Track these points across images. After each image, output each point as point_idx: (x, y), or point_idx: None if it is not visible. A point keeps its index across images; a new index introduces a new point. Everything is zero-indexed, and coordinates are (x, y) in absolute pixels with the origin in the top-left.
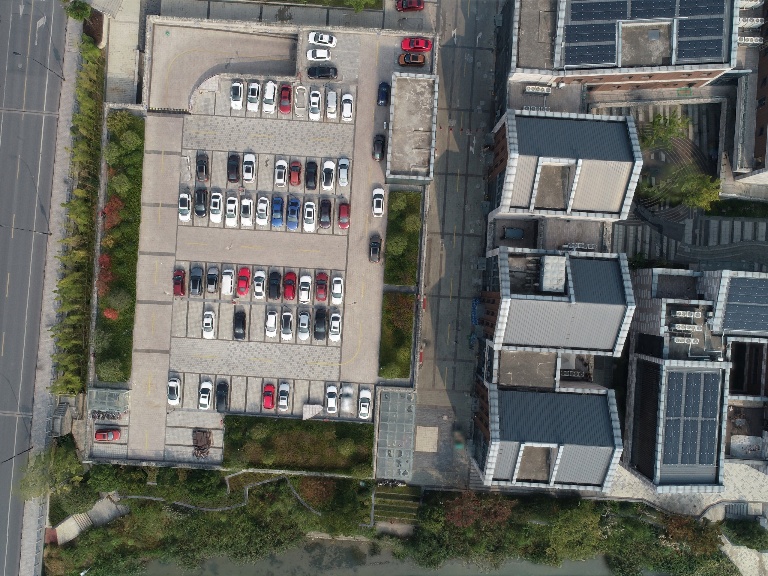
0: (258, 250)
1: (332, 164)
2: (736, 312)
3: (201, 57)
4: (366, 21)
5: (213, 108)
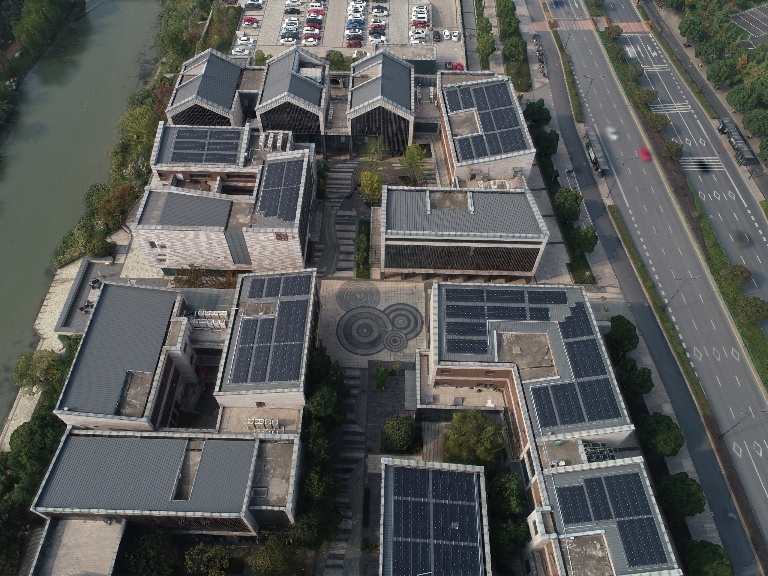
0: (335, 18)
1: (384, 39)
2: (279, 168)
3: (440, 2)
4: (475, 65)
5: (413, 4)
